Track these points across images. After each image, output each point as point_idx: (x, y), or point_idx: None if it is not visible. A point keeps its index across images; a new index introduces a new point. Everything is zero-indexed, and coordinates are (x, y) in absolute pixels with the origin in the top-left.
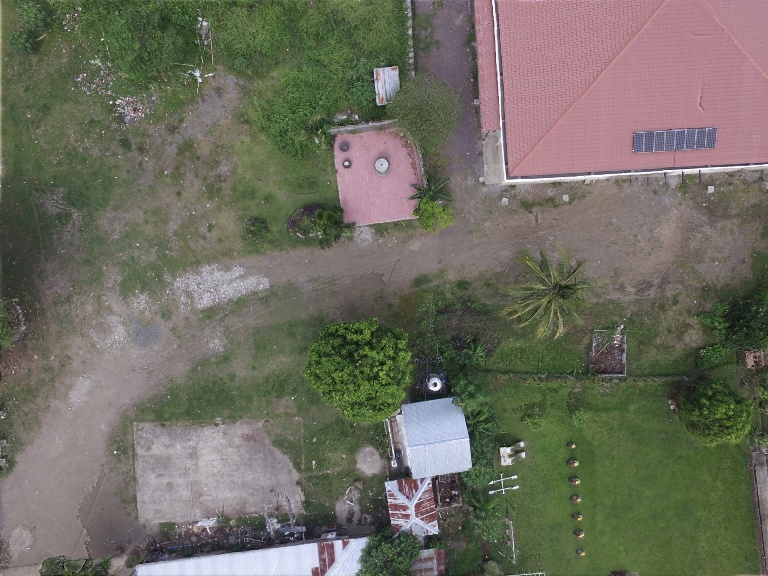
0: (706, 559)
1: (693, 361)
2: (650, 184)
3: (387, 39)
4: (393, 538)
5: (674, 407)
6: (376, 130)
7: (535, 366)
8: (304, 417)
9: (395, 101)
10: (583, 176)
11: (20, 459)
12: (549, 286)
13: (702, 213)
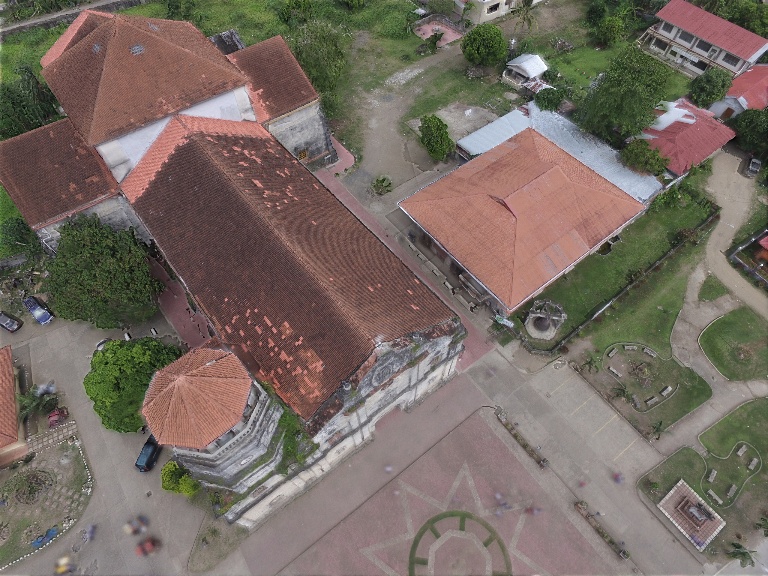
0: None
1: (589, 38)
2: None
3: (409, 6)
4: None
5: (598, 49)
6: (425, 25)
7: None
8: (472, 95)
9: (430, 4)
10: None
11: (363, 154)
12: None
13: (550, 9)
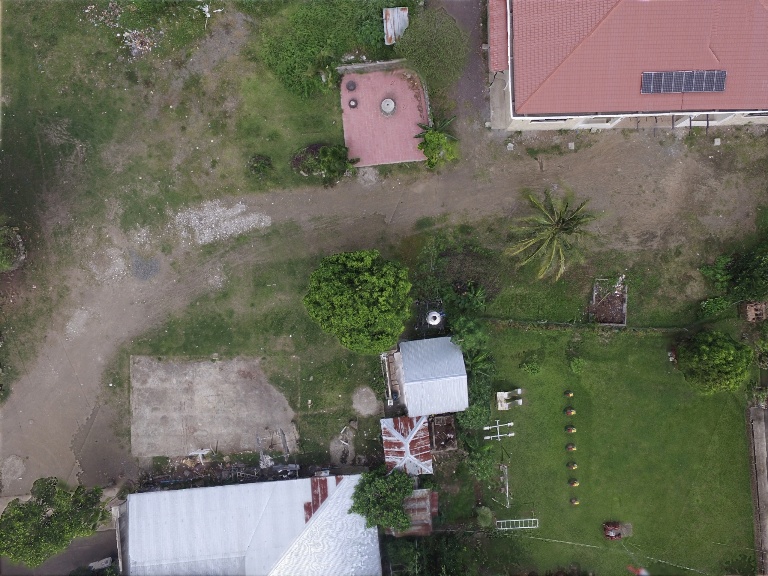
0: (700, 513)
1: (694, 314)
2: (656, 135)
3: None
4: (387, 475)
5: (673, 359)
6: (383, 71)
7: (535, 314)
8: (301, 356)
9: (403, 37)
10: (590, 116)
11: (15, 388)
12: (552, 222)
13: (708, 165)
